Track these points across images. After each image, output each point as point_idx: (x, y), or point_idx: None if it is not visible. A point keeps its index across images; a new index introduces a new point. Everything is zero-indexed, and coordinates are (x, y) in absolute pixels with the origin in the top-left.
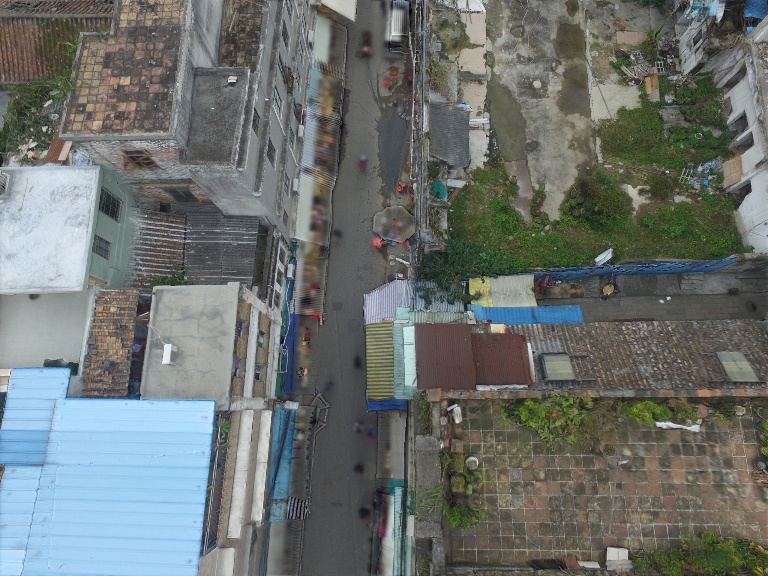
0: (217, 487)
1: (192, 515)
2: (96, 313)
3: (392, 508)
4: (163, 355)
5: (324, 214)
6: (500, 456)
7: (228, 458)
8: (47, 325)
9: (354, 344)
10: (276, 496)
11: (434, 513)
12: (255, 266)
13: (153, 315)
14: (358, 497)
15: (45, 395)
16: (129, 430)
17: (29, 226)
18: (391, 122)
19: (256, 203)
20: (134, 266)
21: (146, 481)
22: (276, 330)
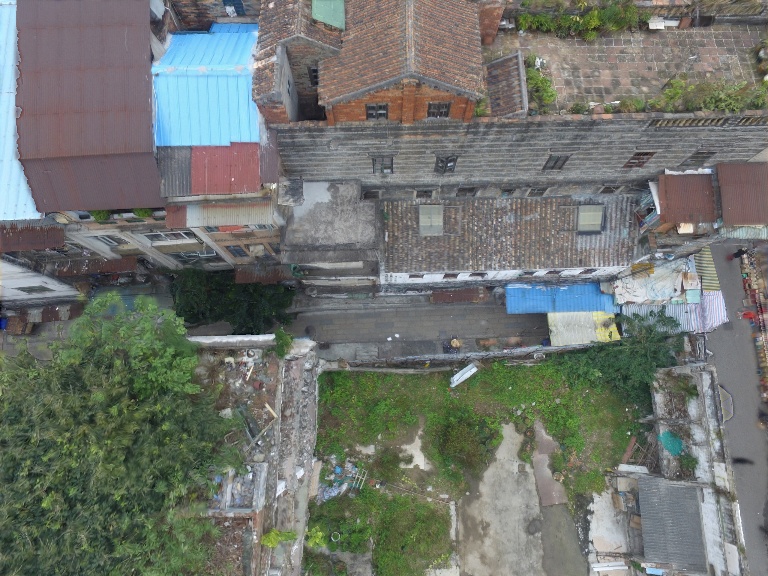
0: None
1: None
2: None
3: None
4: None
5: None
6: None
7: None
8: None
9: None
10: None
11: None
12: None
13: None
14: None
15: None
16: None
17: None
18: None
19: None
20: None
21: None
22: None
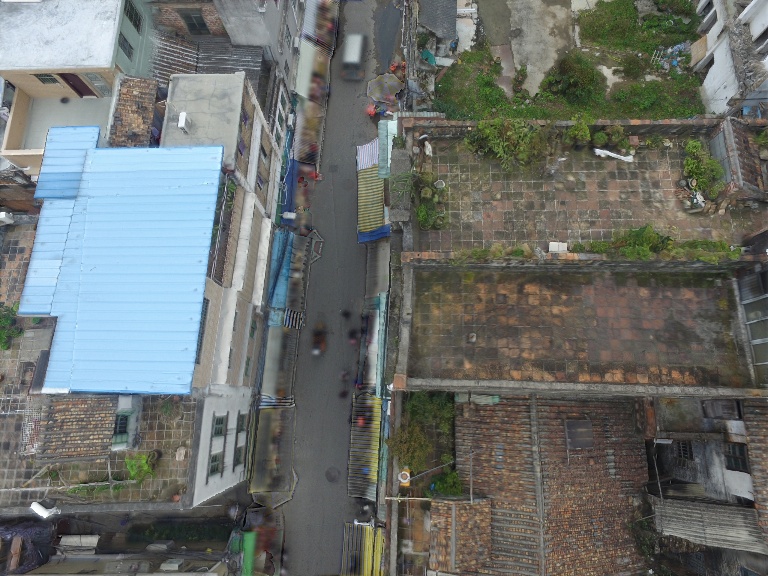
0: (223, 244)
1: (202, 228)
2: (121, 95)
3: (378, 320)
4: (179, 120)
5: (322, 78)
6: (464, 183)
7: (233, 221)
8: (76, 124)
9: (348, 200)
10: (274, 305)
11: (404, 196)
12: (259, 101)
13: (170, 96)
14: (349, 327)
15: (78, 146)
16: (150, 169)
17: (64, 20)
18: (386, 12)
19: (261, 25)
20: (152, 77)
21: (164, 206)
22: (277, 165)
